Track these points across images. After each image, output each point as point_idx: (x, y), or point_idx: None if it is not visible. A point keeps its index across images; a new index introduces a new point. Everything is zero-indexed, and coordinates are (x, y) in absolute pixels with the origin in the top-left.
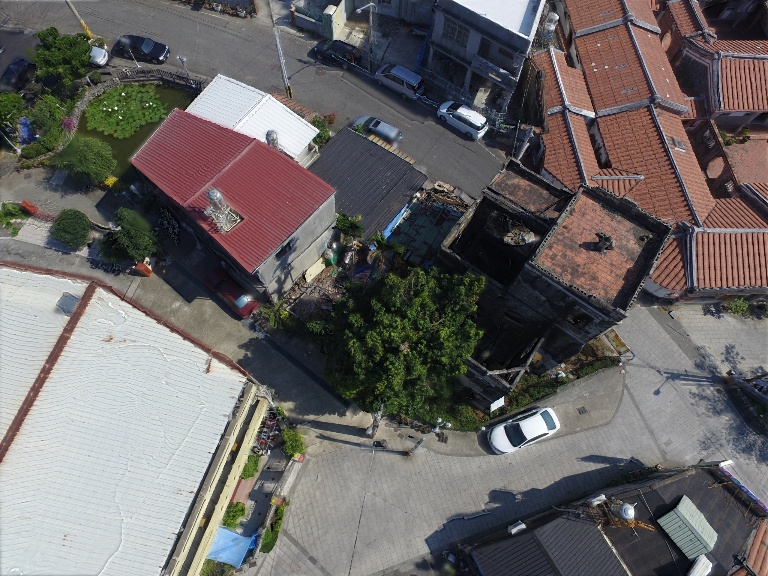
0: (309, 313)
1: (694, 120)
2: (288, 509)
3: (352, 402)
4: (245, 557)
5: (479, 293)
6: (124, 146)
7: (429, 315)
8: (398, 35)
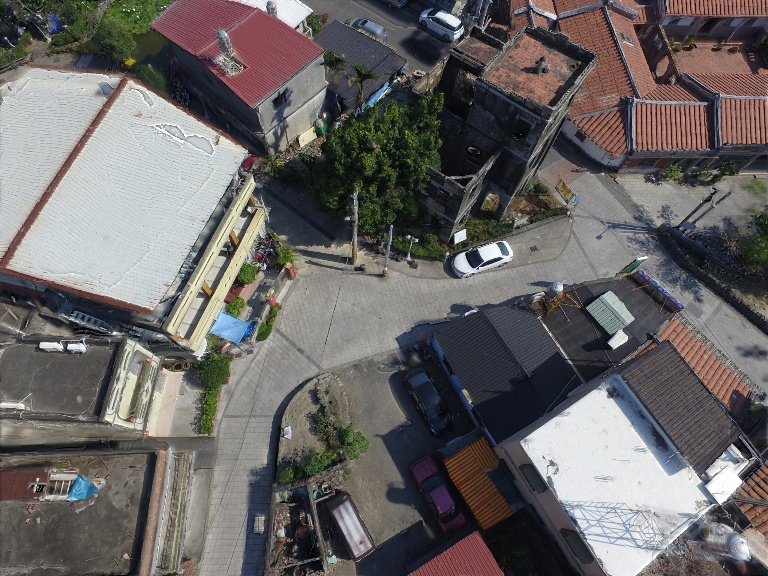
0: (302, 170)
1: (645, 26)
2: (281, 314)
3: (337, 237)
4: (244, 336)
5: (445, 135)
6: (141, 40)
7: (398, 130)
8: None
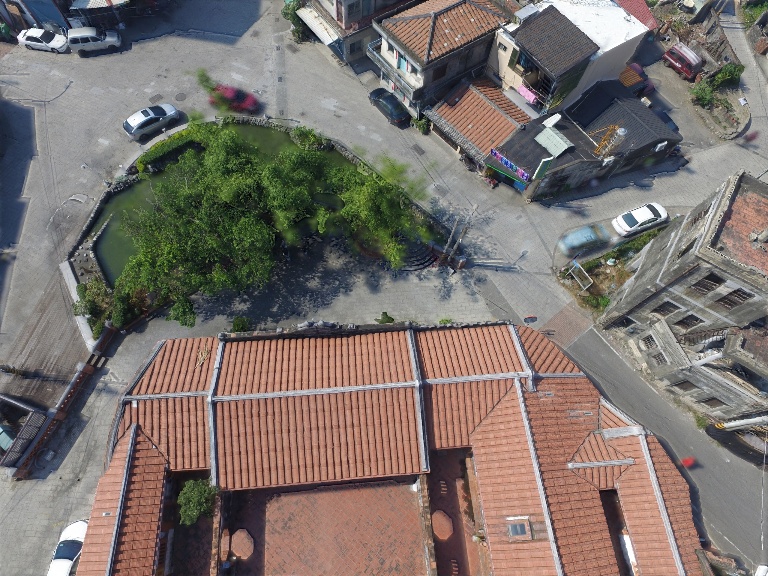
0: None
1: None
2: None
3: None
4: None
5: None
6: None
7: None
8: None
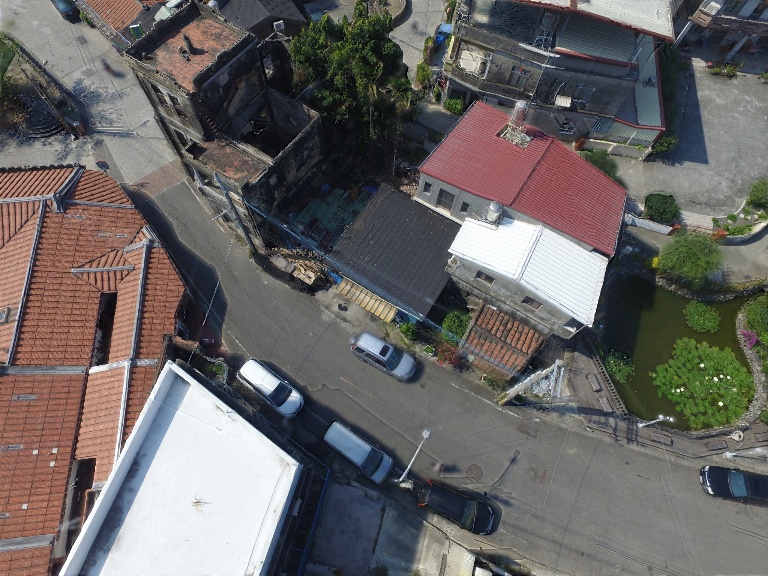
0: None
1: None
2: None
3: None
4: None
5: None
6: (675, 328)
7: None
8: (360, 575)
